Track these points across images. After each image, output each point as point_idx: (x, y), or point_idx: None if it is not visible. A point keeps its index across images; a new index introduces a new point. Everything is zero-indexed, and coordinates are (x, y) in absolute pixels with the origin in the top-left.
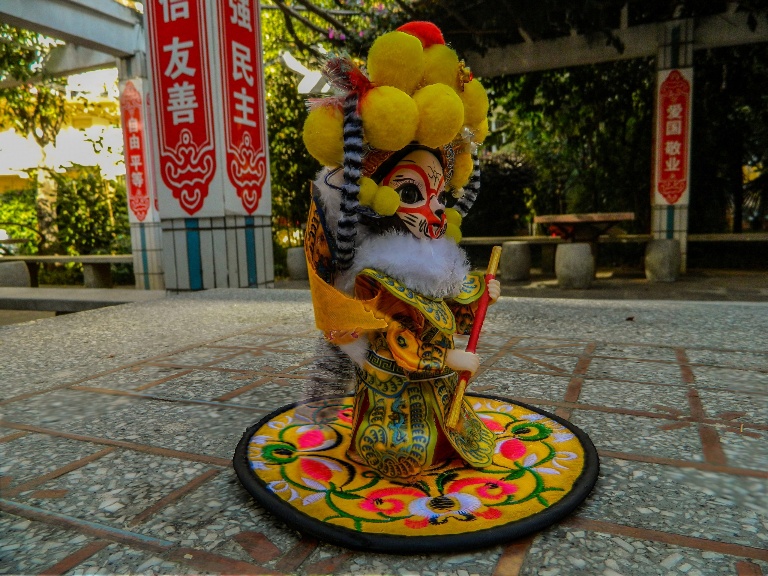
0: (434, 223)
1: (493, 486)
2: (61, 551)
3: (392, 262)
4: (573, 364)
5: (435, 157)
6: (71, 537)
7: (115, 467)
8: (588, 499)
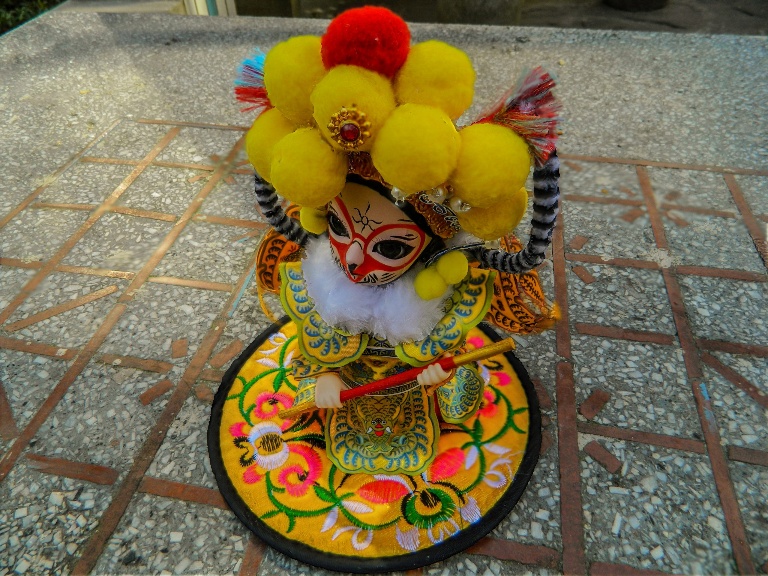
0: None
1: (302, 477)
2: (223, 278)
3: (304, 273)
4: None
5: (386, 198)
6: (237, 274)
7: None
8: None
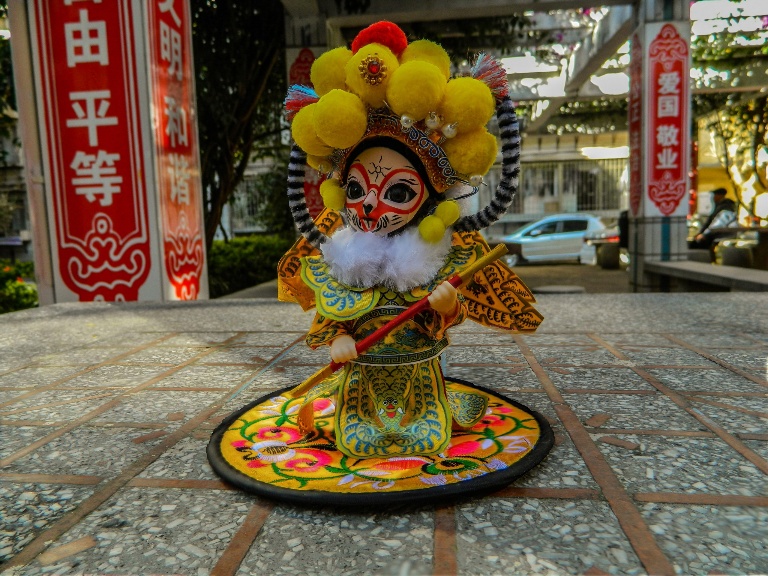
0: (363, 217)
1: (311, 463)
2: None
3: None
4: None
5: (394, 151)
6: None
7: (316, 371)
8: (312, 512)
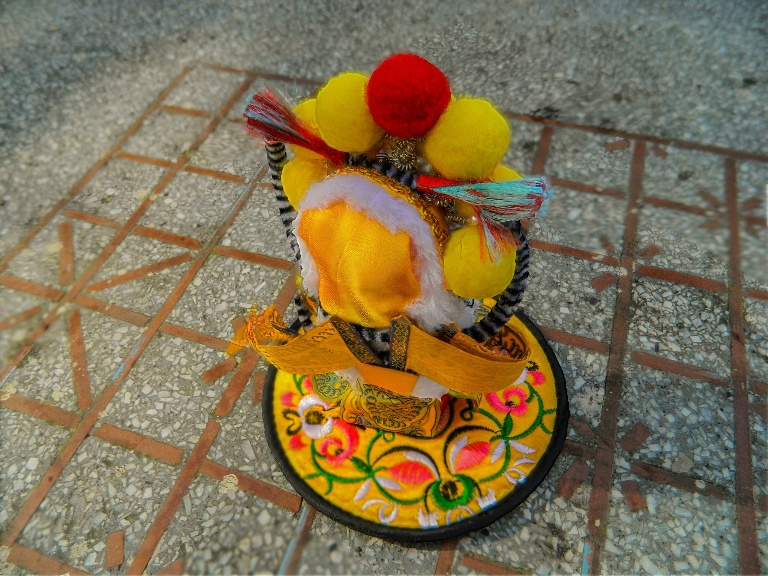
0: None
1: None
2: None
3: None
4: (161, 244)
5: None
6: None
7: None
8: None
